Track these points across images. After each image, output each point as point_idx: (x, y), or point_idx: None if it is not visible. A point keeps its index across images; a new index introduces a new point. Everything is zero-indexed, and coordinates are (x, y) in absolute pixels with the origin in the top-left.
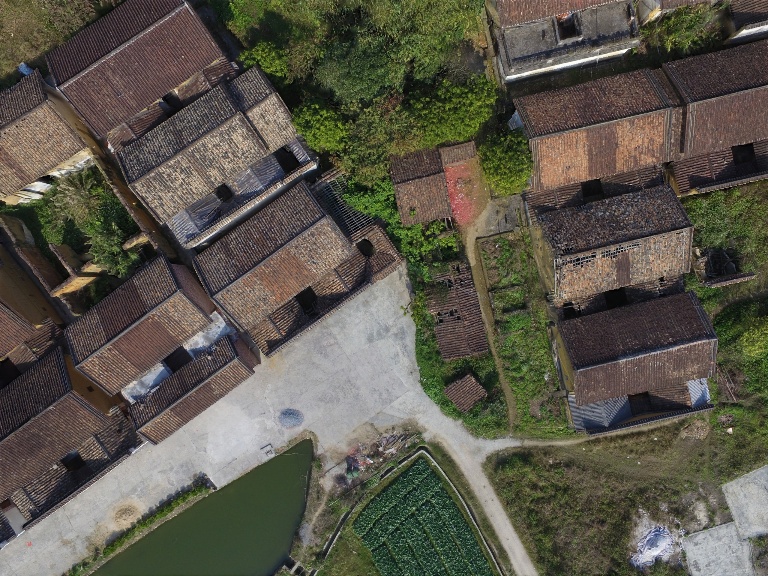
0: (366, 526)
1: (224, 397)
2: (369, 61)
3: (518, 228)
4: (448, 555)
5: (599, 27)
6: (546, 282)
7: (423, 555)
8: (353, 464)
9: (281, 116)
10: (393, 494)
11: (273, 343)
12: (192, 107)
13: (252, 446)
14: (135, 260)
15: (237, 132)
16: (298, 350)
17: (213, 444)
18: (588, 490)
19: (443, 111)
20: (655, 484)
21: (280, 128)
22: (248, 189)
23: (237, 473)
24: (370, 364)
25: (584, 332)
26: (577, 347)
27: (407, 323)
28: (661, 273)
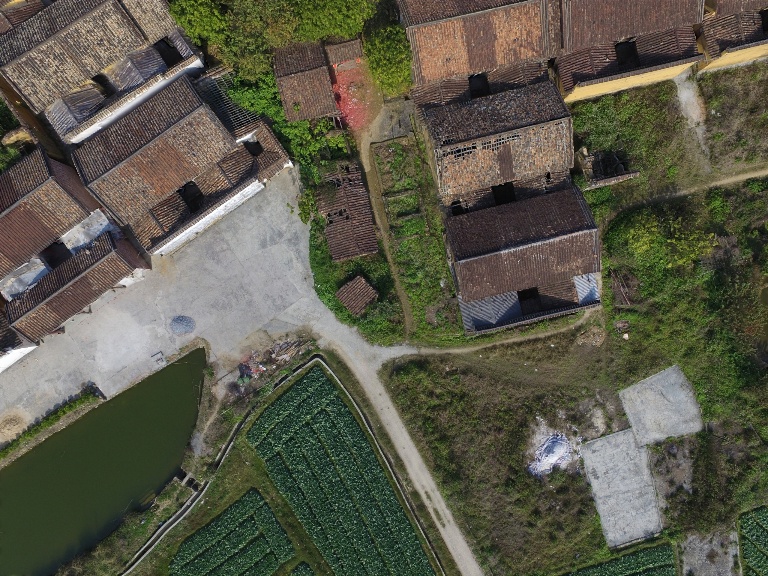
0: (259, 435)
1: (114, 304)
2: None
3: (412, 133)
4: (343, 464)
5: None
6: (437, 184)
7: (317, 465)
8: (246, 372)
9: (159, 5)
10: (287, 402)
11: (156, 241)
12: None
13: (142, 354)
14: (16, 157)
15: (112, 18)
16: (190, 256)
17: (102, 352)
18: (485, 397)
19: None
20: (552, 391)
21: (159, 18)
22: (130, 83)
23: (127, 382)
24: (263, 270)
25: (469, 227)
26: (461, 240)
27: (301, 228)
28: (545, 168)
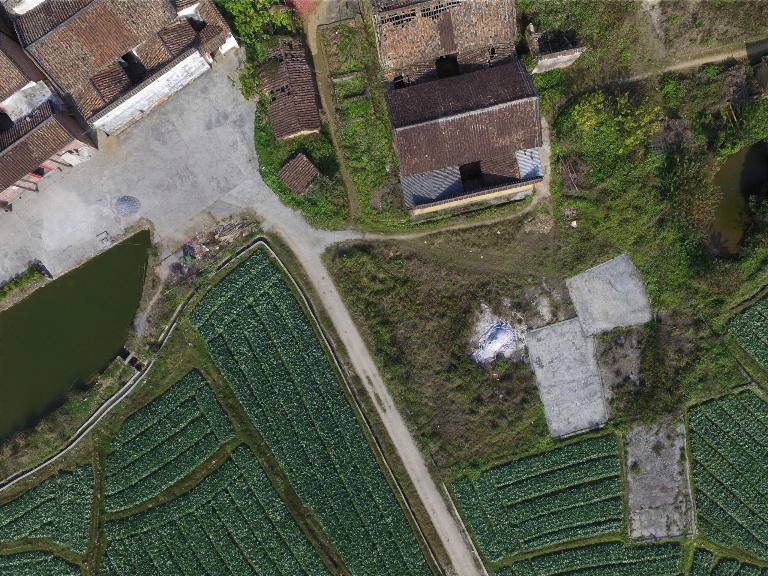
0: (202, 316)
1: (60, 183)
2: None
3: (359, 15)
4: (284, 347)
5: None
6: None
7: (259, 346)
8: (189, 252)
9: None
10: (229, 283)
11: None
12: None
13: (88, 233)
14: None
15: None
16: (136, 136)
17: (48, 231)
18: (429, 283)
19: None
20: (498, 278)
21: None
22: None
23: (72, 260)
24: (208, 151)
25: (408, 98)
26: (399, 111)
27: (246, 110)
28: (487, 39)
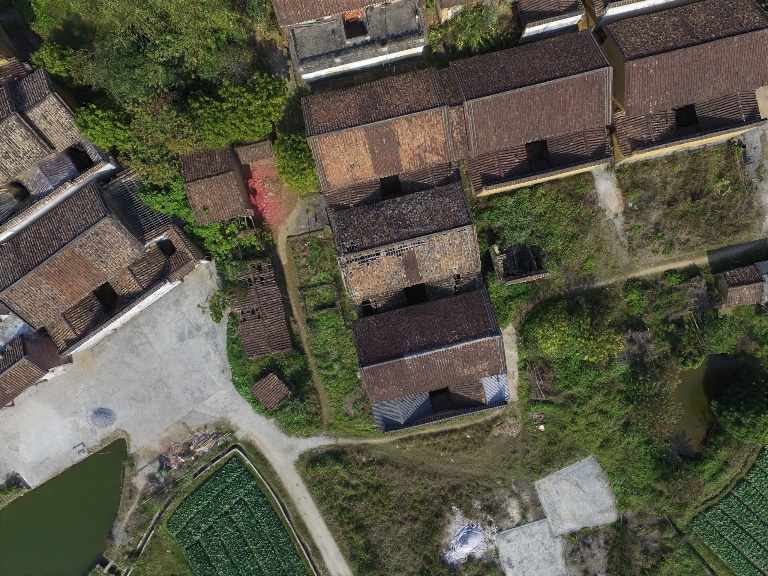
0: (179, 525)
1: (36, 396)
2: (122, 61)
3: (328, 227)
4: (261, 553)
5: (388, 26)
6: None
7: (236, 553)
8: (165, 463)
9: (63, 116)
10: (205, 492)
11: (70, 342)
12: None
13: (65, 445)
14: None
15: (15, 132)
16: (110, 349)
17: (25, 443)
18: (401, 488)
19: (220, 110)
20: (468, 481)
21: (64, 128)
22: (40, 189)
23: (50, 472)
24: (182, 363)
25: (375, 330)
26: (366, 345)
27: None
28: (451, 271)
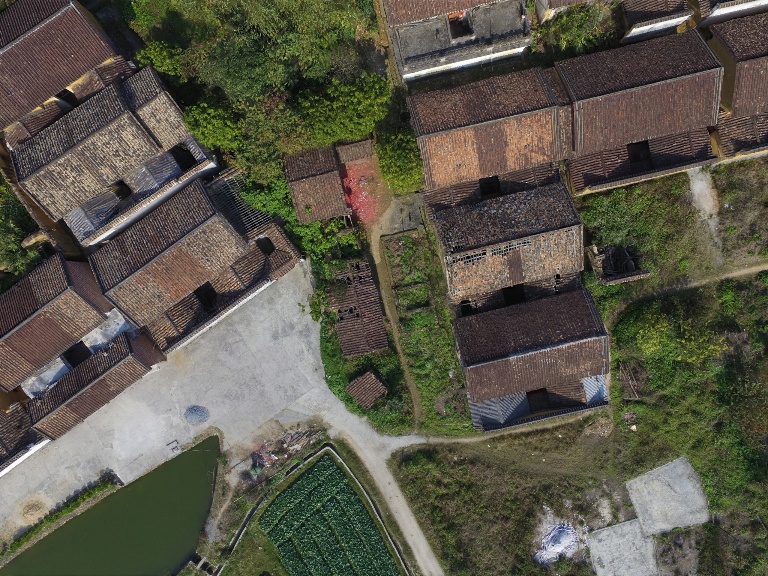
0: (271, 522)
1: (130, 394)
2: (245, 60)
3: (422, 226)
4: (353, 551)
5: (492, 26)
6: None
7: (328, 551)
8: (258, 460)
9: (172, 115)
10: (298, 490)
11: (171, 340)
12: (85, 106)
13: (158, 442)
14: (35, 257)
15: (126, 130)
16: (204, 347)
17: (119, 440)
18: (492, 487)
19: (331, 109)
20: (559, 481)
21: (172, 126)
22: (145, 187)
23: (143, 469)
24: (275, 361)
25: (478, 329)
26: (470, 344)
27: (312, 320)
28: (554, 271)
